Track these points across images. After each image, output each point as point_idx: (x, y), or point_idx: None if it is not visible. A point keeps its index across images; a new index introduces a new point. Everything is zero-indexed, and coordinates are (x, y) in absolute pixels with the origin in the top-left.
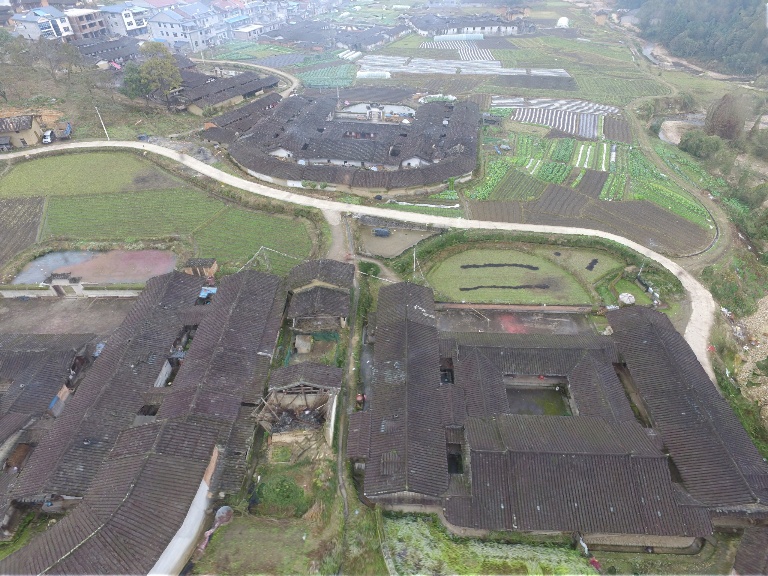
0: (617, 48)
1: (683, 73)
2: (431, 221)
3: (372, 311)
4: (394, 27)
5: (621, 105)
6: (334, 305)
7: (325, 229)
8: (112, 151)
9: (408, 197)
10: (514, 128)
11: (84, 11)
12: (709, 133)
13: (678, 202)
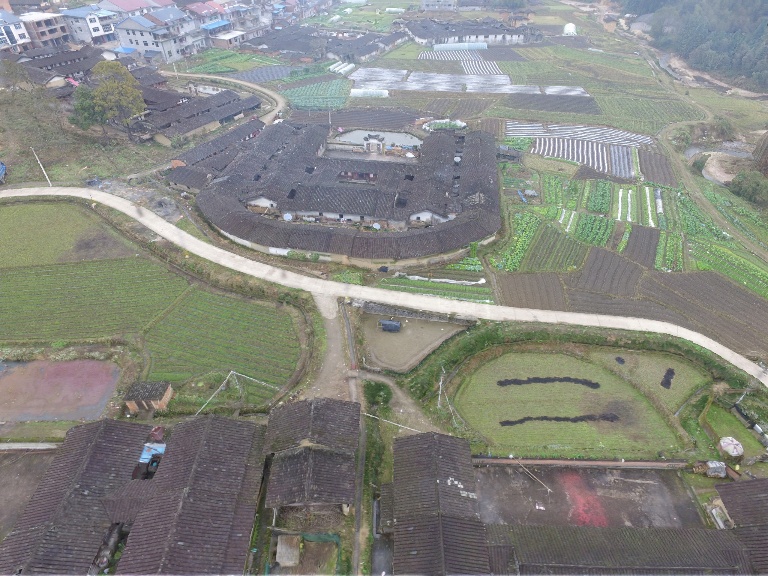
0: (634, 60)
1: (710, 91)
2: (453, 309)
3: (385, 470)
4: (389, 34)
5: (653, 133)
6: (333, 483)
7: (317, 325)
8: (53, 201)
9: (420, 268)
10: (537, 165)
11: (43, 15)
12: (761, 171)
13: (753, 274)
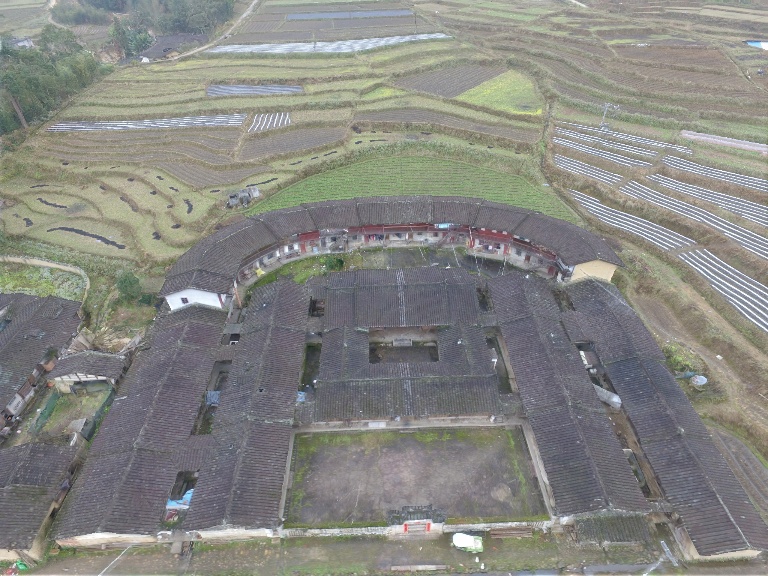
0: None
1: None
2: None
3: None
4: None
5: None
6: (4, 462)
7: None
8: None
9: None
10: None
11: None
12: None
13: None
